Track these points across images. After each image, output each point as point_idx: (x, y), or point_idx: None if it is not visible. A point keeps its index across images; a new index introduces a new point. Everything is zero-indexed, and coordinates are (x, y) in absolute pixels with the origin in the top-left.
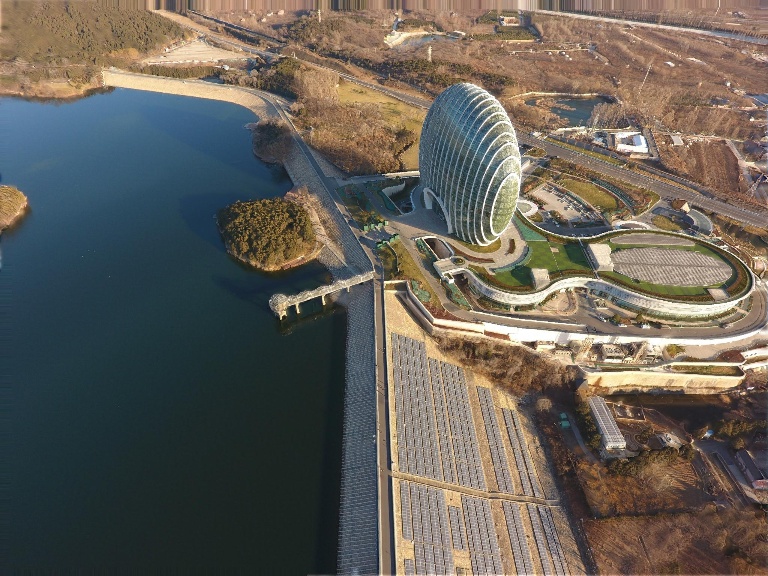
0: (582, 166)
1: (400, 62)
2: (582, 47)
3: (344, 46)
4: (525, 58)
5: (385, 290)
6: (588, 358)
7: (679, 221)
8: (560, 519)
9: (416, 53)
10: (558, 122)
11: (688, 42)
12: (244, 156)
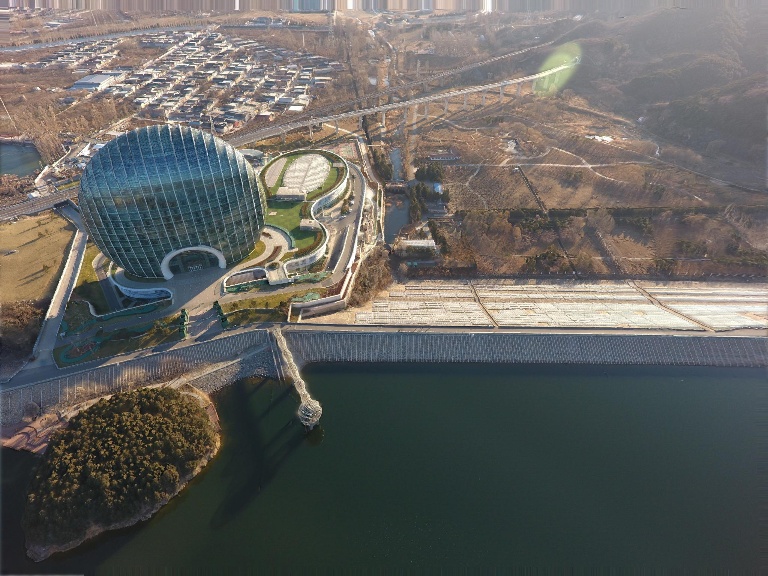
0: None
1: None
2: None
3: None
4: None
5: None
6: None
7: None
8: (479, 282)
9: None
10: (8, 181)
11: None
12: None
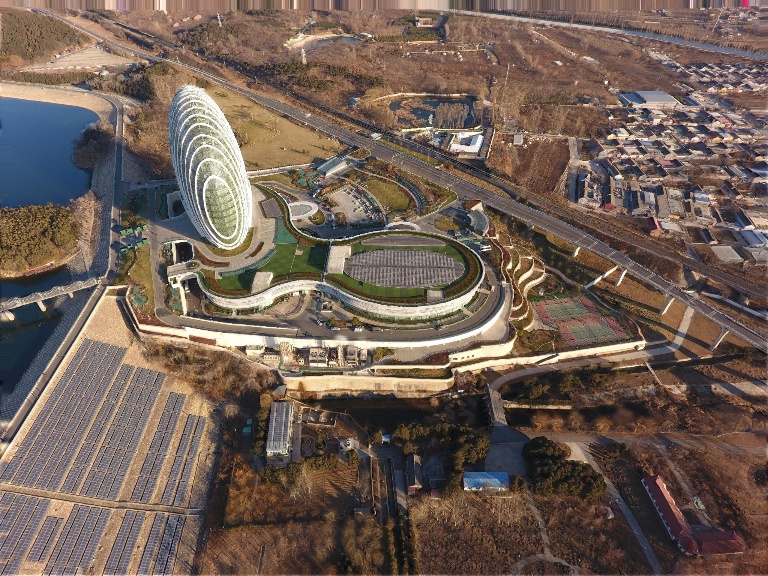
0: (397, 167)
1: (274, 65)
2: (480, 47)
3: (235, 50)
4: (415, 59)
5: (105, 296)
6: (296, 362)
7: (462, 221)
8: (191, 528)
9: (300, 56)
10: (412, 123)
11: (587, 41)
12: (59, 161)
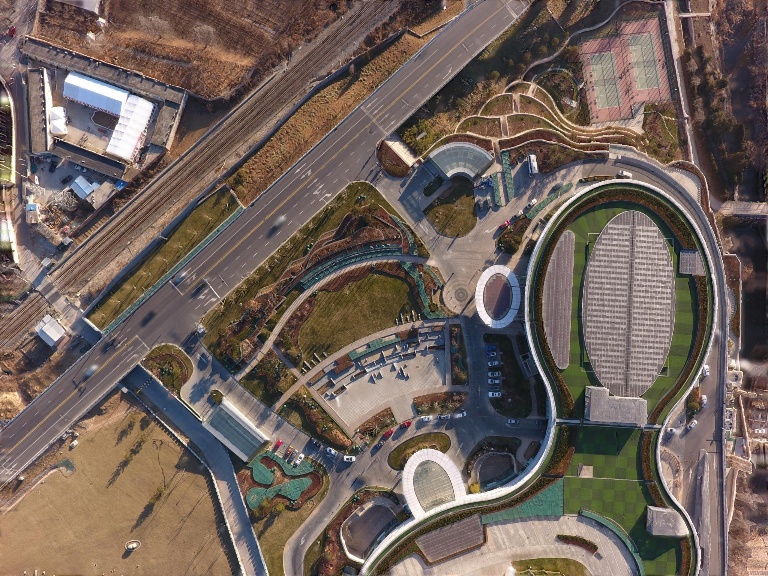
0: (238, 288)
1: None
2: None
3: None
4: None
5: None
6: None
7: (447, 188)
8: None
9: None
10: None
11: None
12: None
